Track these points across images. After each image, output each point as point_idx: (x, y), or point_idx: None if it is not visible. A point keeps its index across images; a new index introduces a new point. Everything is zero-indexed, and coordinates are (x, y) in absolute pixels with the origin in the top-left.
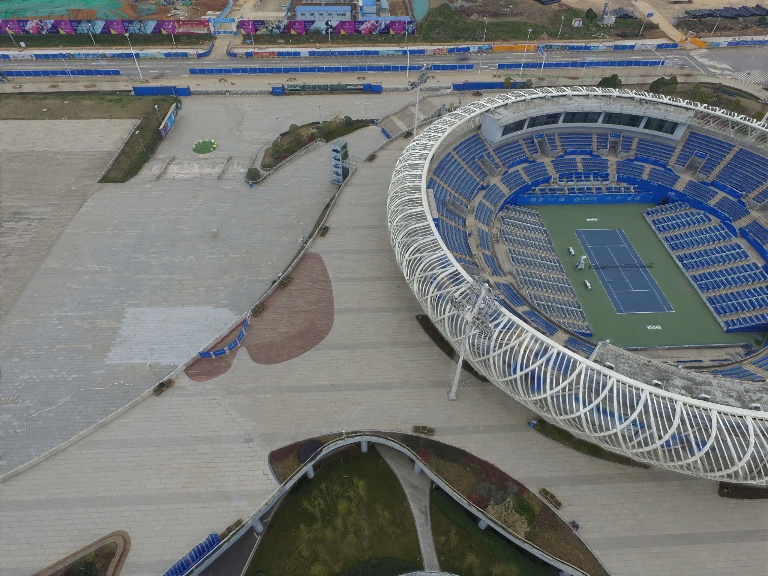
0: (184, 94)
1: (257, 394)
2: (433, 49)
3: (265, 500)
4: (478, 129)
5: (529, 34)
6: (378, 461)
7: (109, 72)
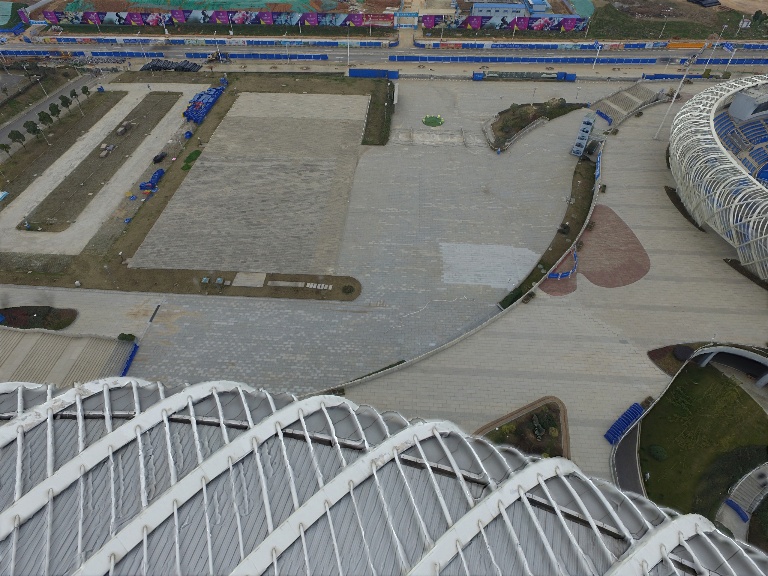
0: (393, 77)
1: (612, 309)
2: (611, 44)
3: (662, 385)
4: (725, 108)
5: (698, 33)
6: (720, 374)
7: (318, 57)
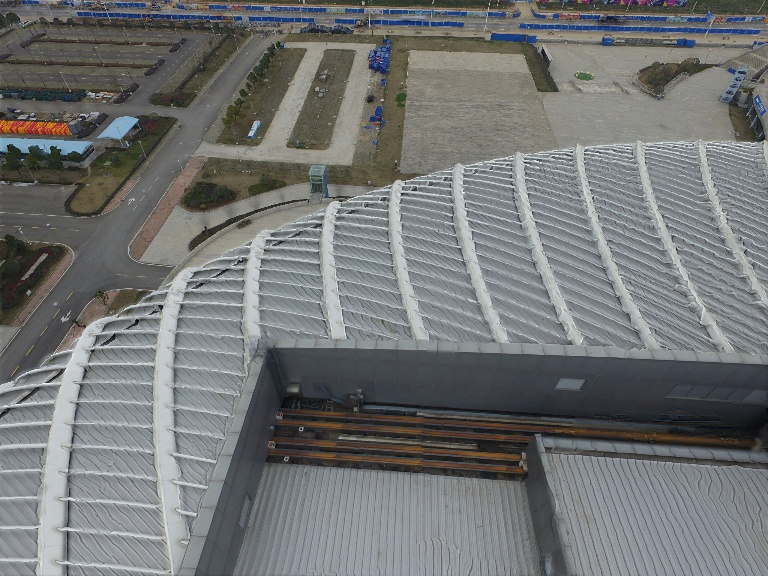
0: (531, 41)
1: None
2: (715, 18)
3: None
4: None
5: None
6: None
7: (455, 24)
